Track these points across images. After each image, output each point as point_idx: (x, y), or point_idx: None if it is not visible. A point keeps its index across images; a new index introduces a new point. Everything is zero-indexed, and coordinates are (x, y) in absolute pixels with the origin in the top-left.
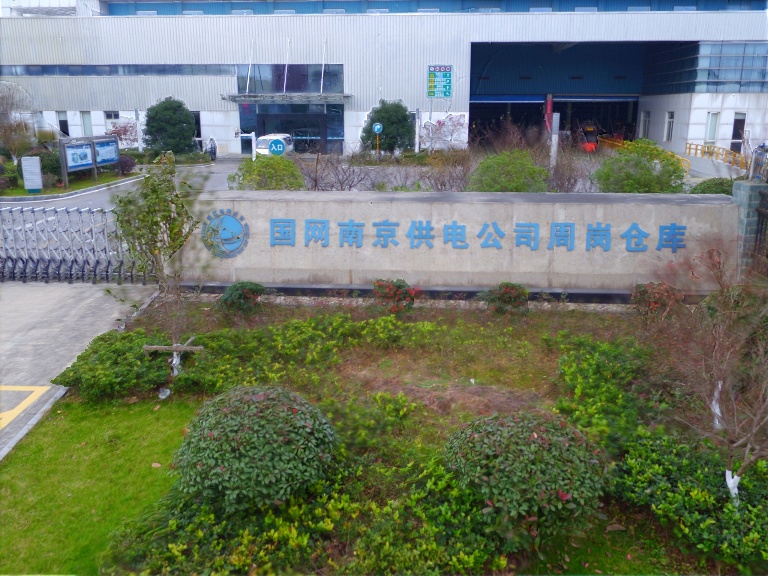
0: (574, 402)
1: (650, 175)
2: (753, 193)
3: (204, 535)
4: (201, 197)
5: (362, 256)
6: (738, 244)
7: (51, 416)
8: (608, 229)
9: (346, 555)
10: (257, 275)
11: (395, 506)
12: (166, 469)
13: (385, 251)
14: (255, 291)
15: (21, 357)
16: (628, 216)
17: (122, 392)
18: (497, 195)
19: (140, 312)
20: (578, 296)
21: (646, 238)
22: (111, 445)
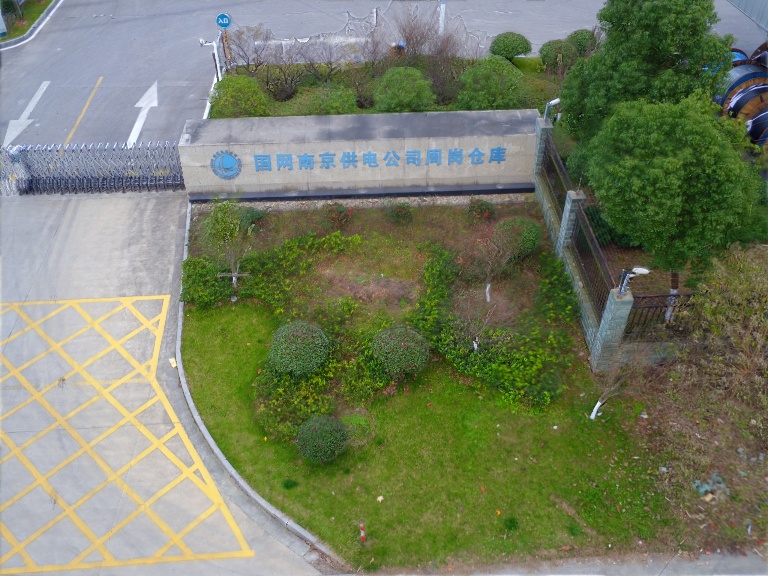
0: (426, 298)
1: (496, 88)
2: (543, 132)
3: (289, 384)
4: (205, 140)
5: (314, 174)
6: (535, 157)
7: (186, 319)
8: (461, 152)
9: (339, 385)
10: (249, 188)
11: (354, 364)
12: (254, 346)
13: (328, 171)
14: (259, 219)
15: (140, 272)
16: (473, 144)
17: (215, 302)
18: (395, 121)
19: (195, 235)
20: (443, 193)
21: (483, 156)
22: (223, 334)
